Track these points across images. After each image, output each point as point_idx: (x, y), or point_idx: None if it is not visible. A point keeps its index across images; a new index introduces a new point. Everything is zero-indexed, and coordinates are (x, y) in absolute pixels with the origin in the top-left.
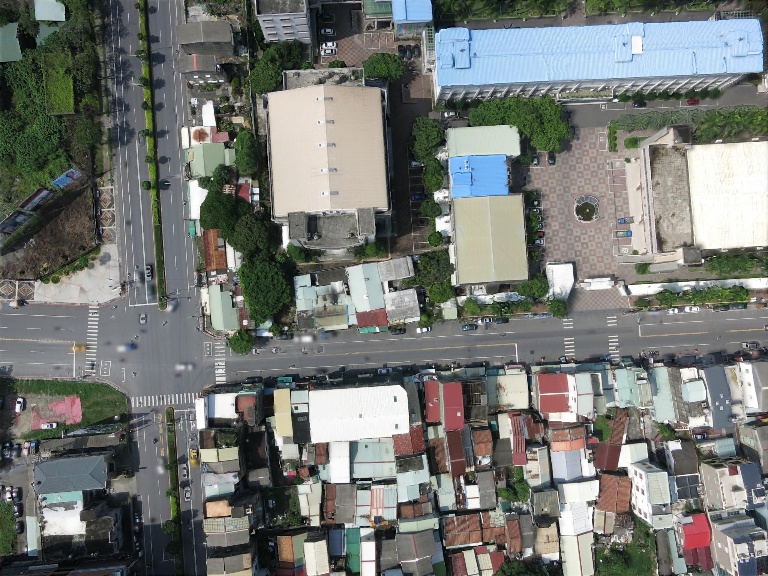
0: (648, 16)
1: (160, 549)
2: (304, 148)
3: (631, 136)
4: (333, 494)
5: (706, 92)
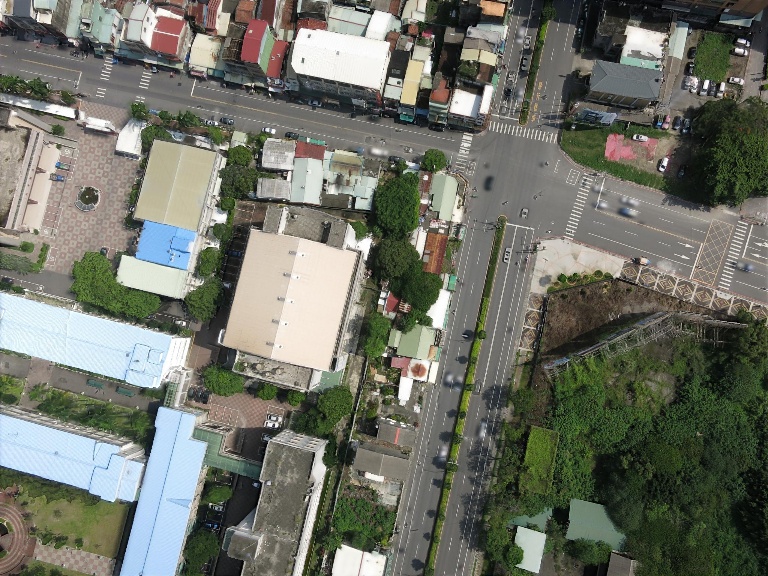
0: None
1: (566, 0)
2: (308, 306)
3: (26, 254)
4: (393, 4)
5: None
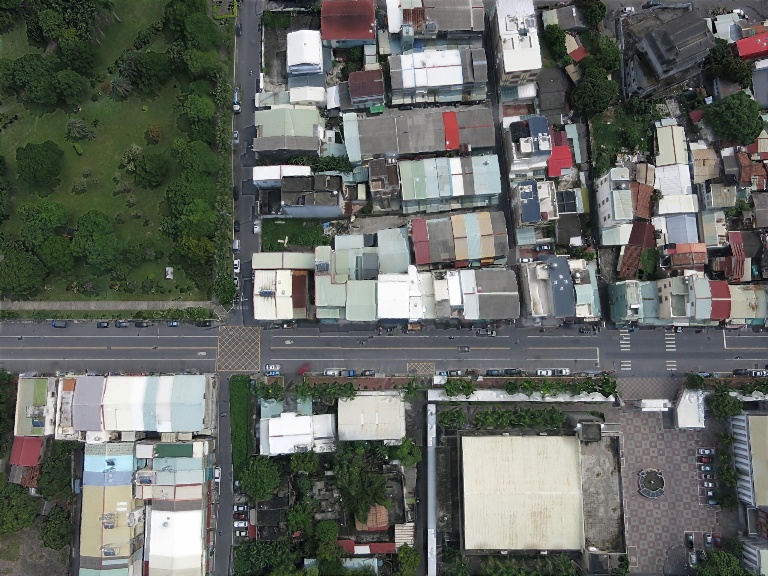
0: None
1: None
2: None
3: None
4: None
5: None
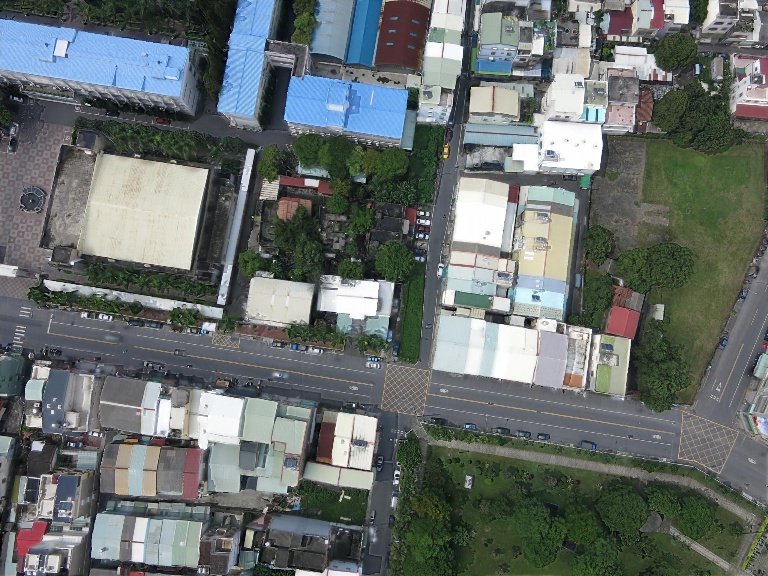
0: (145, 35)
1: None
2: None
3: None
4: None
5: (166, 112)
